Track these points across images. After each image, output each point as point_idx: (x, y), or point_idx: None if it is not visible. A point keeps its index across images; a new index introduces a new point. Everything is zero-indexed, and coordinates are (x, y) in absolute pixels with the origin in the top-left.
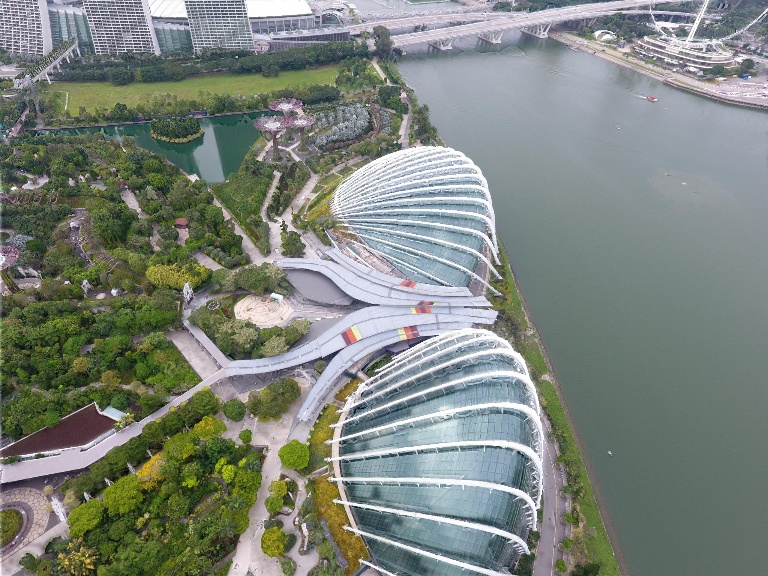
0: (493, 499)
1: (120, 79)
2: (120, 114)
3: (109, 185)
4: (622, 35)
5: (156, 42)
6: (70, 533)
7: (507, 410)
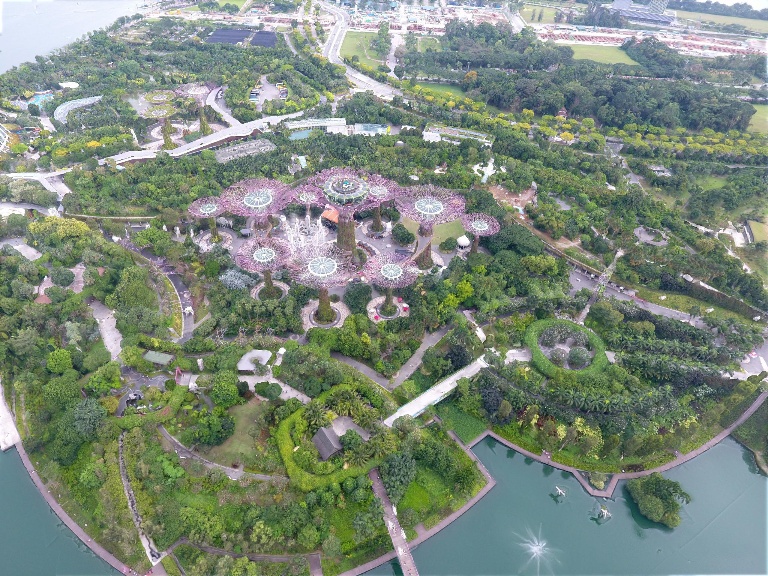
0: None
1: None
2: None
3: None
4: None
5: None
6: None
7: None
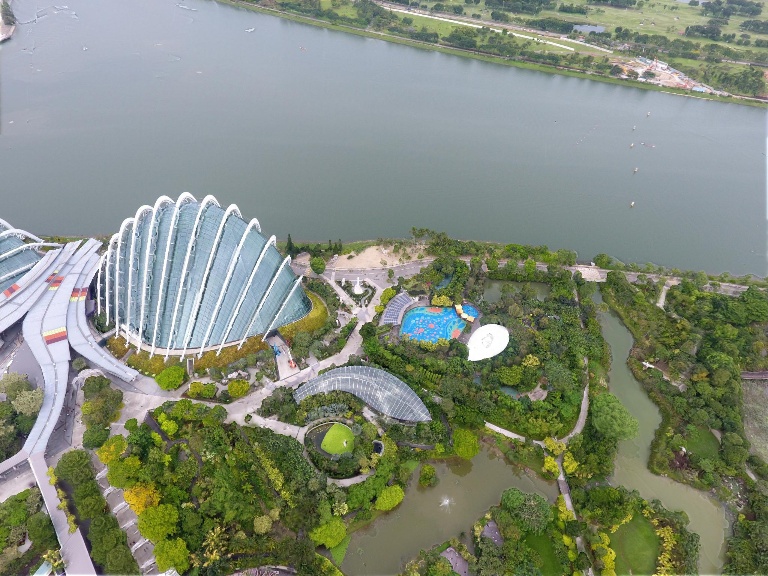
0: (254, 234)
1: None
2: None
3: None
4: None
5: None
6: (183, 567)
7: (206, 207)
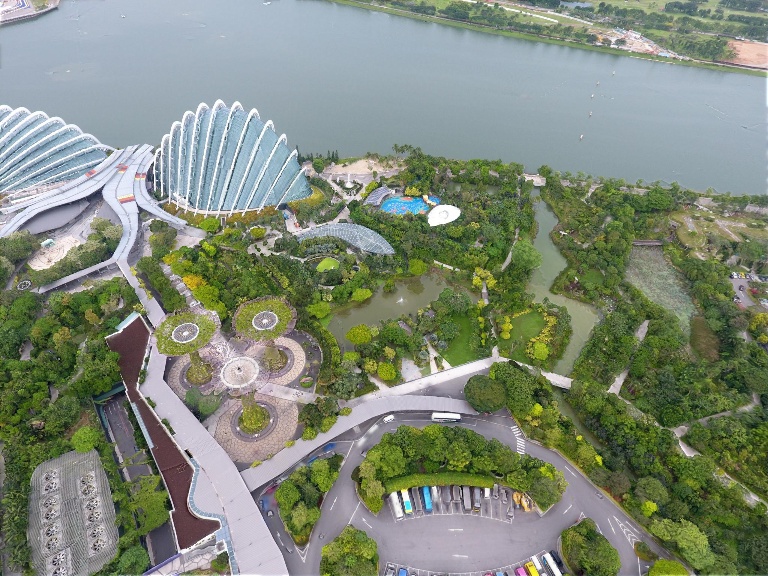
0: (271, 132)
1: None
2: None
3: None
4: None
5: None
6: (223, 315)
7: None
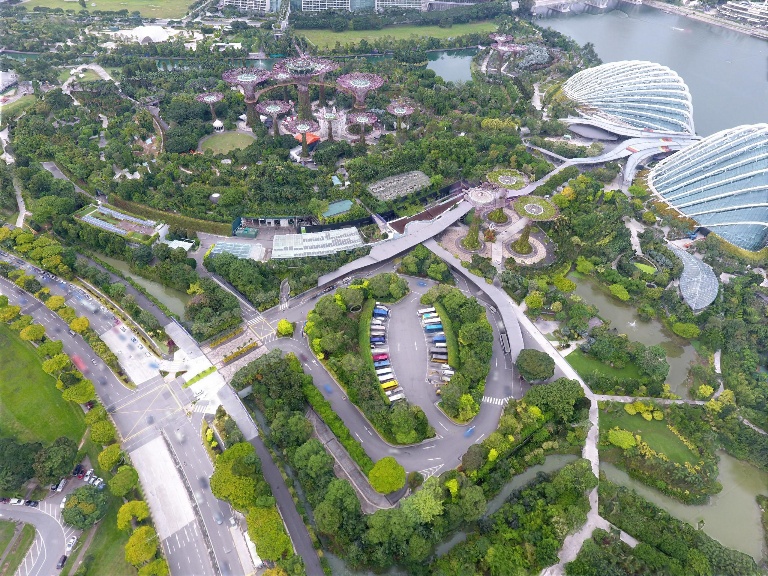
0: None
1: (340, 27)
2: (365, 48)
3: (408, 84)
4: (705, 2)
5: (349, 1)
6: None
7: None
